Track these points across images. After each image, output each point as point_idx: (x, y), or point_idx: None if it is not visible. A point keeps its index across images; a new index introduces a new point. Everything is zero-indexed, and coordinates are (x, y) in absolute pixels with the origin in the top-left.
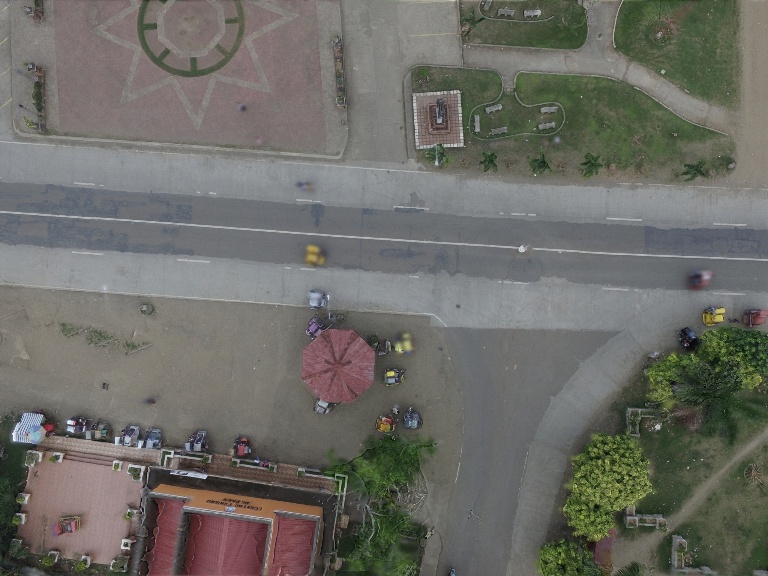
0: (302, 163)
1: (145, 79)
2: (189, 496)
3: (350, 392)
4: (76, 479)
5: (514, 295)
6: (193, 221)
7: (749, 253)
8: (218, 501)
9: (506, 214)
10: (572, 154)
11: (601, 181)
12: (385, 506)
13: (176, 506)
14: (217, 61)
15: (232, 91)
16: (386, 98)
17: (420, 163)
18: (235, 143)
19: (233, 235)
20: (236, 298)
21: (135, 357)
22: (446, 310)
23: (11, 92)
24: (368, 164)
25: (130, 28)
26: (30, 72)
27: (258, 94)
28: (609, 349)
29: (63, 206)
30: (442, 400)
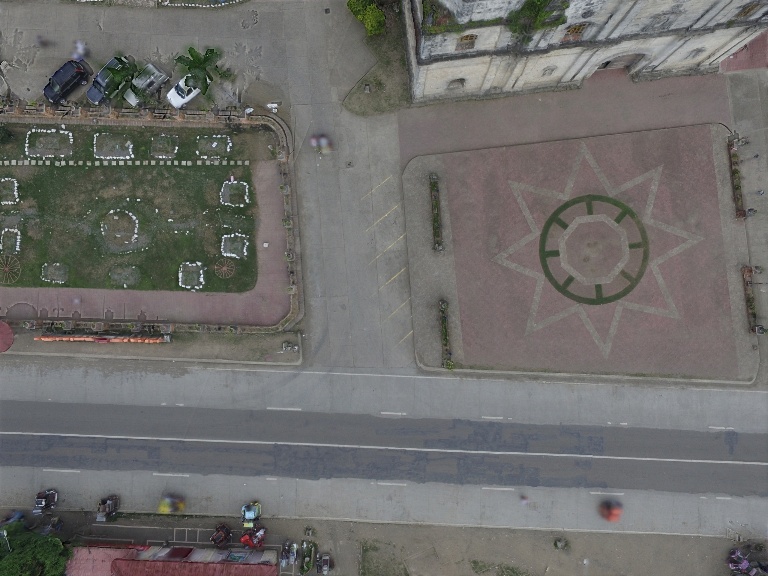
0: (713, 389)
1: (550, 308)
2: None
3: None
4: None
5: None
6: (605, 453)
7: None
8: None
9: None
10: None
11: None
12: None
13: None
14: (623, 288)
15: (640, 318)
16: None
17: None
18: (645, 372)
19: (647, 466)
20: (651, 530)
21: None
22: None
23: (412, 325)
24: None
25: (532, 256)
26: (431, 304)
27: (667, 320)
28: None
29: (472, 441)
30: None
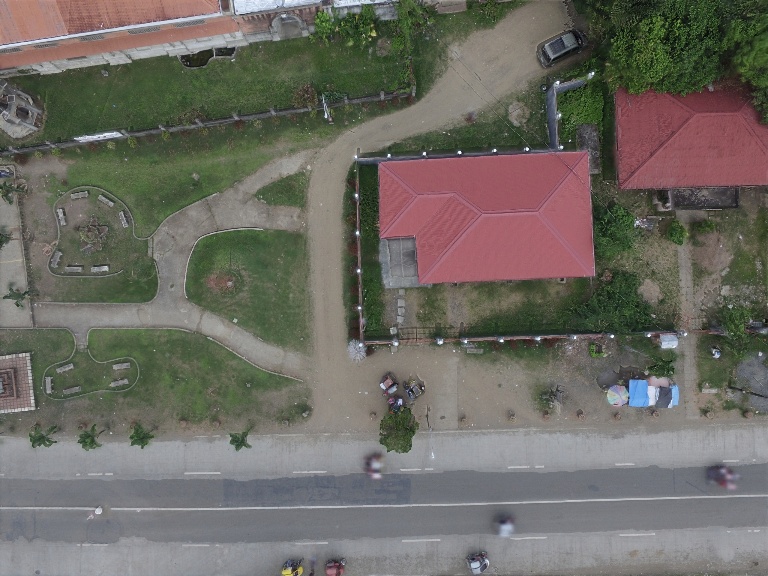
0: None
1: None
2: None
3: None
4: None
5: (93, 558)
6: None
7: (330, 500)
8: None
9: (83, 475)
10: (146, 410)
11: (178, 435)
12: None
13: None
14: None
15: None
16: None
17: None
18: None
19: None
20: None
21: None
22: None
23: None
24: None
25: None
26: None
27: None
28: None
29: None
30: None
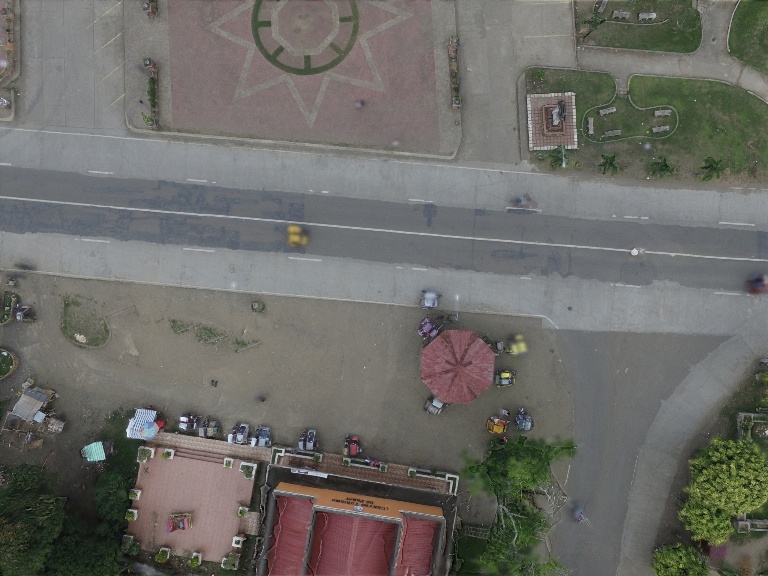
0: (415, 163)
1: (259, 76)
2: (315, 495)
3: (470, 393)
4: (187, 476)
5: (626, 298)
6: (305, 219)
7: None
8: (343, 500)
9: (619, 217)
10: (685, 158)
11: (714, 185)
12: (525, 508)
13: (300, 505)
14: (331, 59)
15: (346, 90)
16: (500, 99)
17: (533, 164)
18: (348, 142)
19: (345, 234)
20: (347, 297)
21: (245, 355)
22: (558, 312)
23: (124, 88)
24: (481, 165)
25: (244, 25)
26: (143, 68)
27: (372, 93)
28: (720, 353)
29: (175, 202)
30: (552, 402)
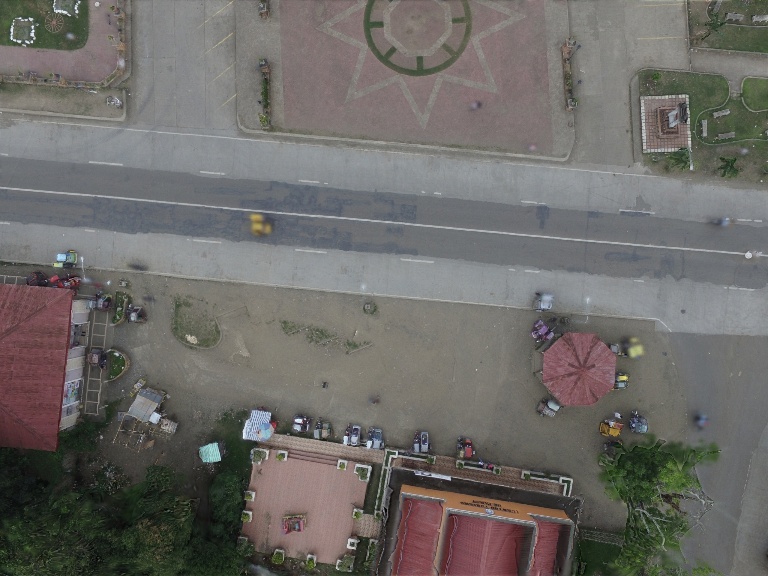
0: (527, 165)
1: (371, 77)
2: (444, 498)
3: (591, 396)
4: (300, 478)
5: (740, 301)
6: (418, 221)
7: None
8: (471, 503)
9: (732, 220)
10: None
11: None
12: (669, 512)
13: (427, 507)
14: (444, 61)
15: (459, 91)
16: (612, 101)
17: (647, 167)
18: (461, 143)
19: (458, 236)
20: (459, 299)
21: (356, 356)
22: (671, 315)
23: (236, 88)
24: (594, 167)
25: (356, 26)
26: (255, 68)
27: (485, 94)
28: None
29: (287, 203)
30: (665, 405)
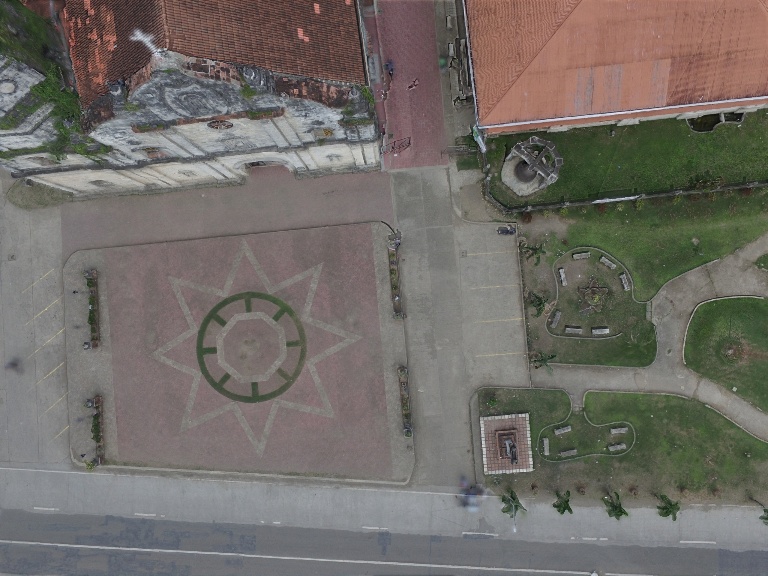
0: (368, 489)
1: (206, 406)
2: None
3: None
4: None
5: None
6: (257, 552)
7: None
8: None
9: (577, 539)
10: (644, 476)
11: None
12: None
13: None
14: (279, 386)
15: (295, 417)
16: (453, 420)
17: (489, 488)
18: (299, 471)
19: (299, 565)
20: None
21: None
22: None
23: (68, 420)
24: (435, 489)
25: (189, 352)
26: None
27: (322, 420)
28: None
29: (124, 538)
30: None
